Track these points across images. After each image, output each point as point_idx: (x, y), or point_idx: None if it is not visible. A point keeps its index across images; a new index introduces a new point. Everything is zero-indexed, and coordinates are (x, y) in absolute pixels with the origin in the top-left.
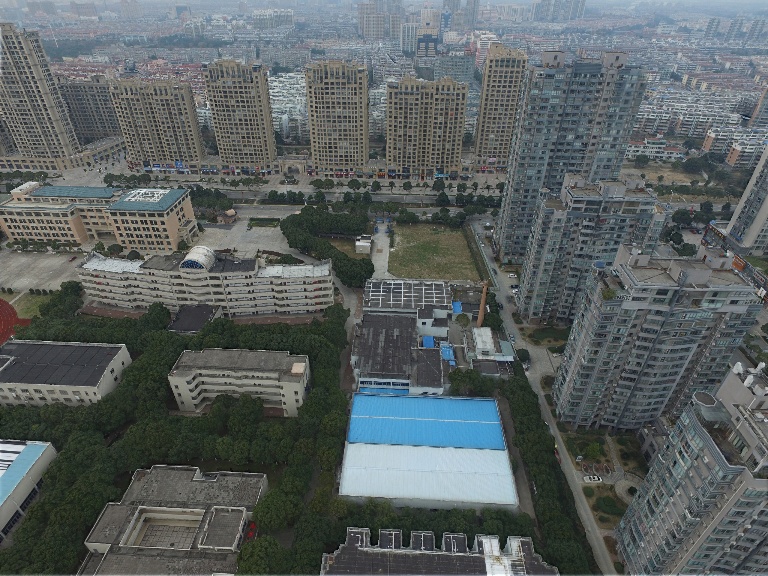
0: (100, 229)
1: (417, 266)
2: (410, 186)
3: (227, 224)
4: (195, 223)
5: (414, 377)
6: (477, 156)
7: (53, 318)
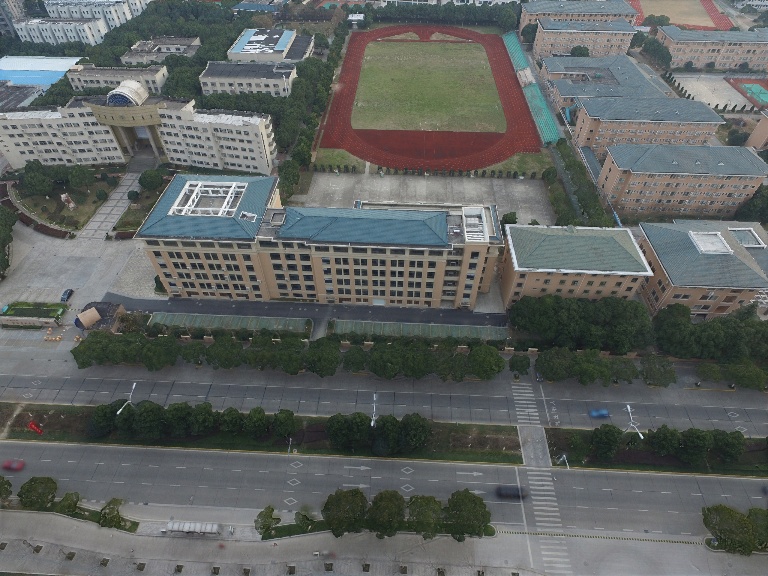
0: None
1: None
2: None
3: None
4: None
5: (2, 87)
6: None
7: None
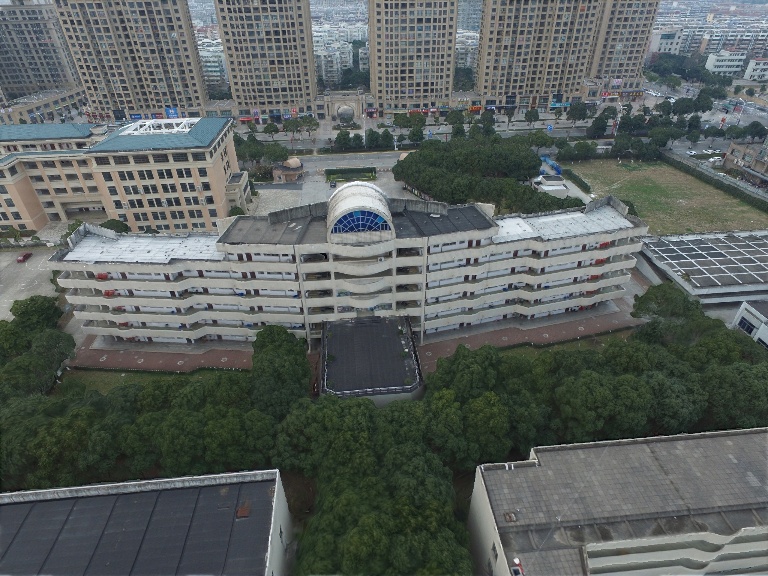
0: (70, 201)
1: (663, 215)
2: (537, 115)
3: (290, 182)
4: (246, 178)
5: None
6: (595, 78)
7: (6, 395)
